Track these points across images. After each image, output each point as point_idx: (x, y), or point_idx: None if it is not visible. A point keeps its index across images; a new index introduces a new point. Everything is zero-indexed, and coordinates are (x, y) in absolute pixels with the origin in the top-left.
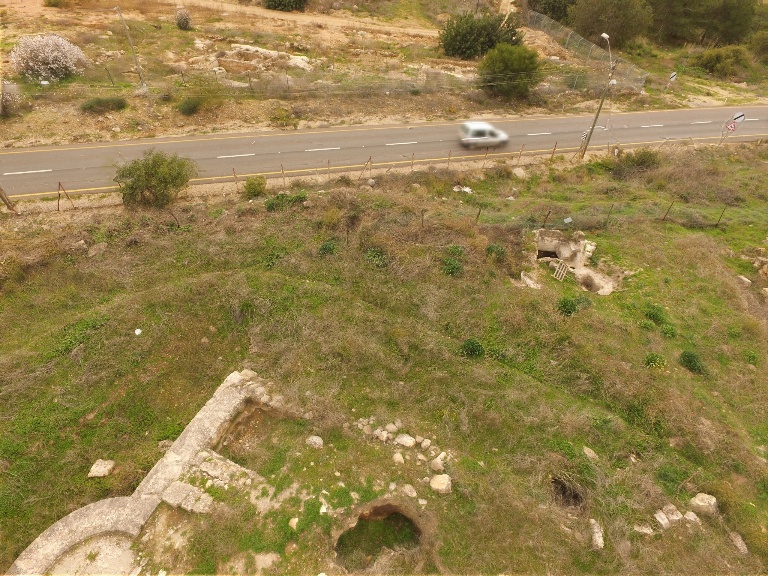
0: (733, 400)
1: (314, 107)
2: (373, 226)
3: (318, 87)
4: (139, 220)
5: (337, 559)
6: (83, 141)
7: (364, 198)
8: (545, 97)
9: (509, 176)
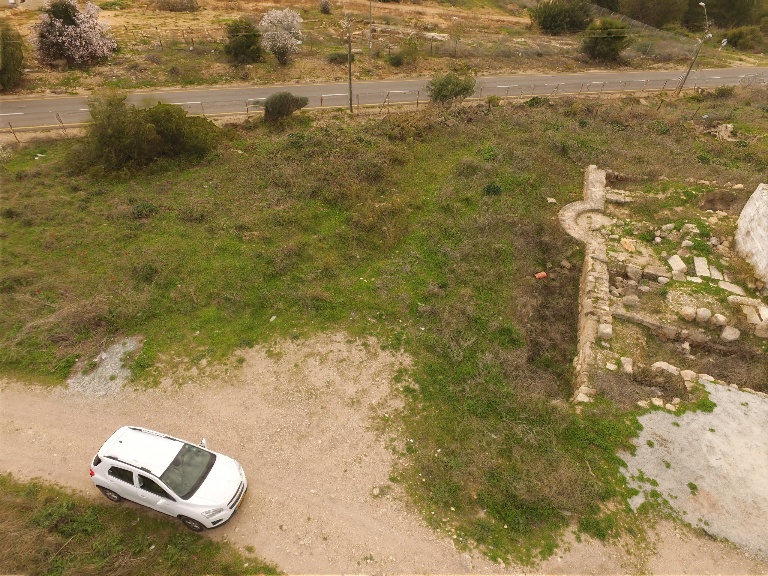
0: None
1: (476, 63)
2: (604, 112)
3: (472, 50)
4: None
5: None
6: None
7: (583, 101)
8: (627, 60)
9: (638, 103)
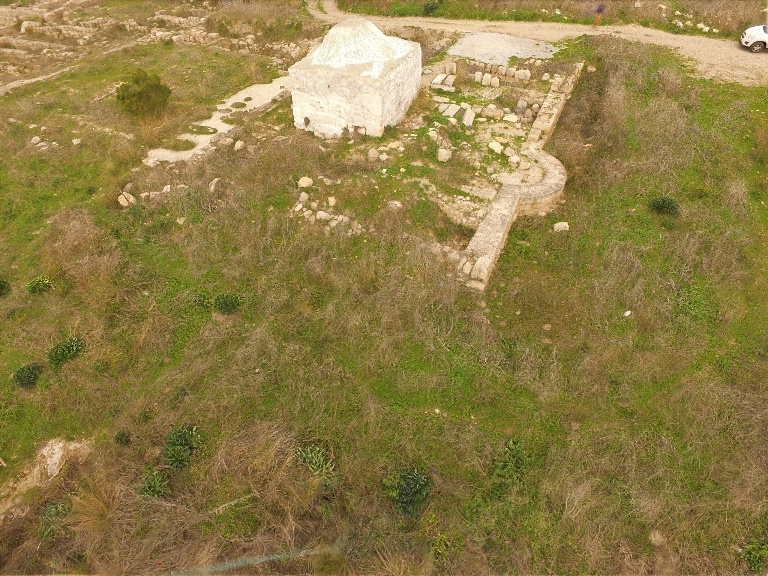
0: (7, 260)
1: None
2: None
3: None
4: None
5: None
6: None
7: None
8: None
9: None
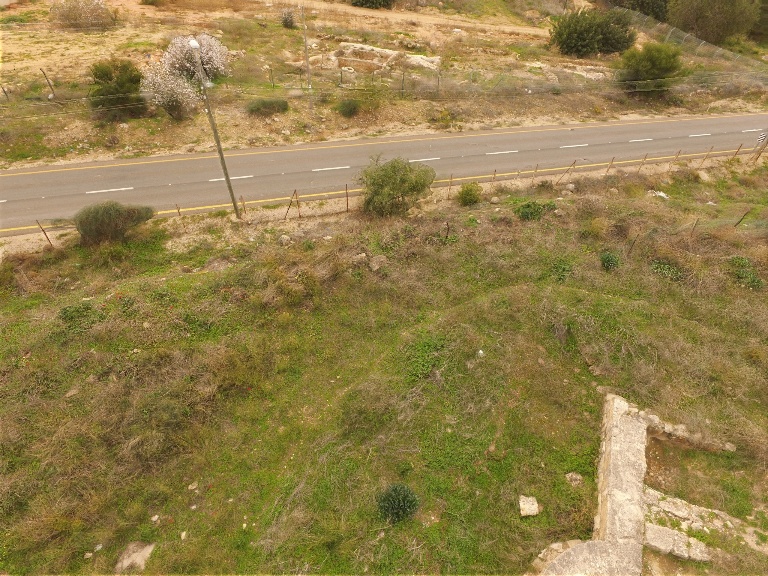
0: None
1: (466, 108)
2: (646, 236)
3: (463, 87)
4: (401, 230)
5: None
6: (260, 145)
7: (611, 206)
8: (678, 96)
9: (697, 180)
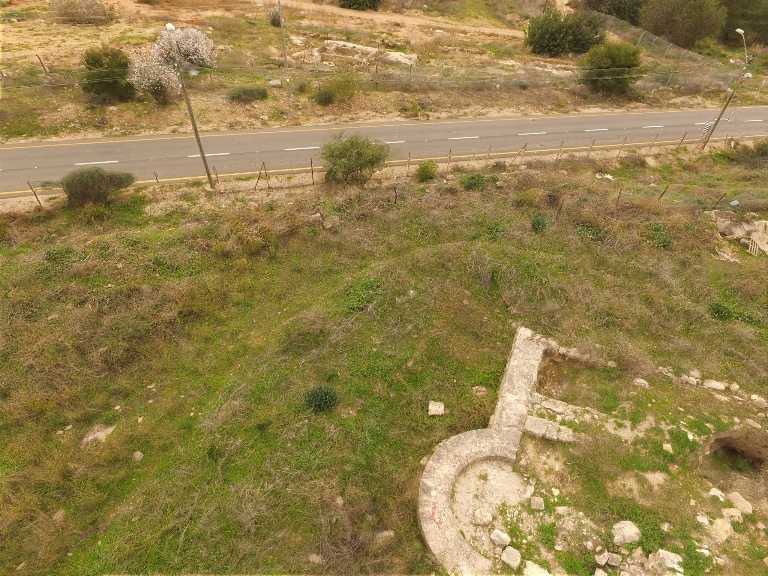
0: None
1: (436, 99)
2: (575, 204)
3: None
4: (355, 196)
5: None
6: (239, 128)
7: (549, 179)
8: (641, 93)
9: (643, 165)
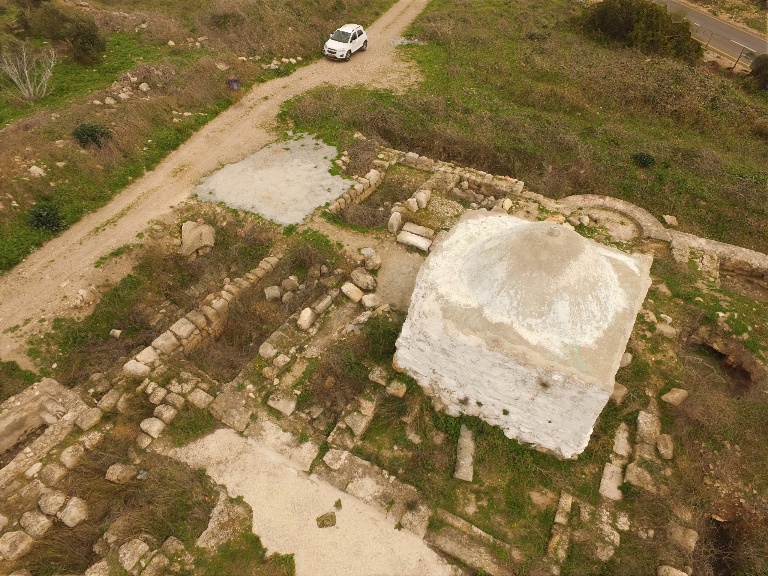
0: None
1: None
2: None
3: None
4: None
5: (681, 341)
6: None
7: None
8: None
9: None
